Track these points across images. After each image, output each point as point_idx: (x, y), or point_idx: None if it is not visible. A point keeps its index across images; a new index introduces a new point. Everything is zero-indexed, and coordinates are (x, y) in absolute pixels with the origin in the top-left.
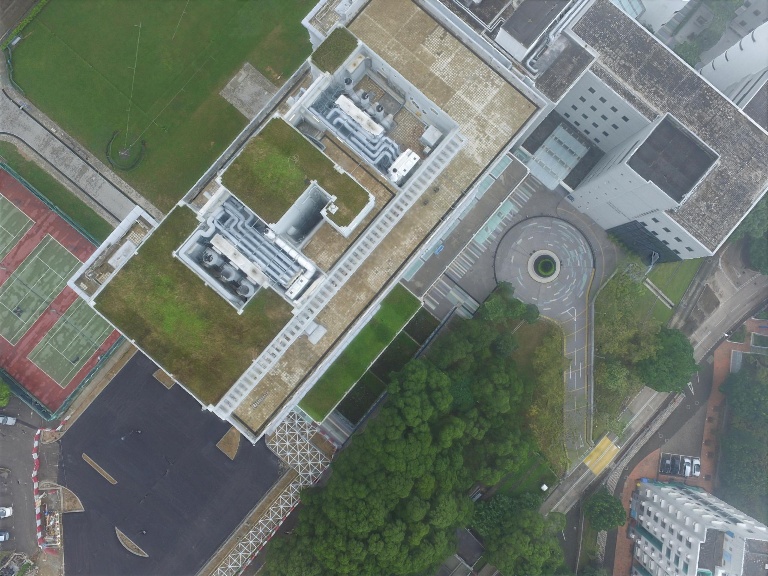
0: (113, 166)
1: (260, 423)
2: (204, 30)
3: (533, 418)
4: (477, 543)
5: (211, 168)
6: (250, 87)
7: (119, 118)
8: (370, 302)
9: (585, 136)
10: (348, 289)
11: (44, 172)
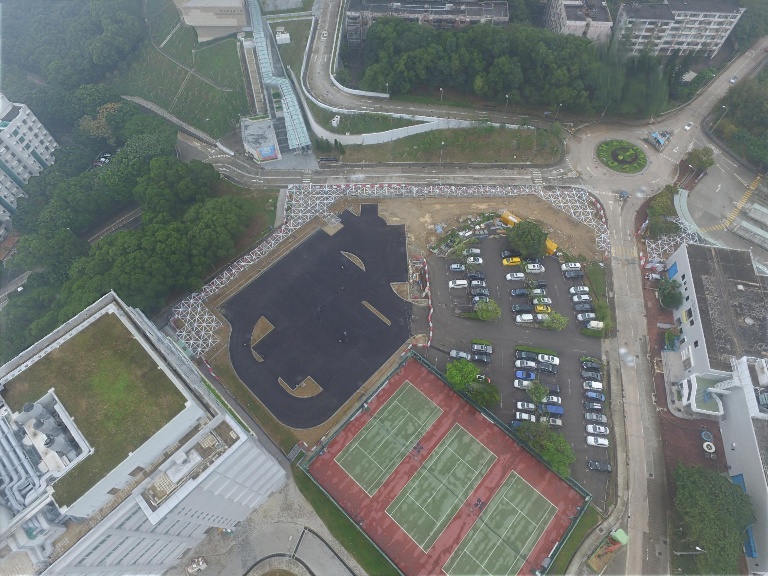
0: None
1: None
2: None
3: None
4: None
5: (48, 569)
6: None
7: None
8: None
9: None
10: None
11: None
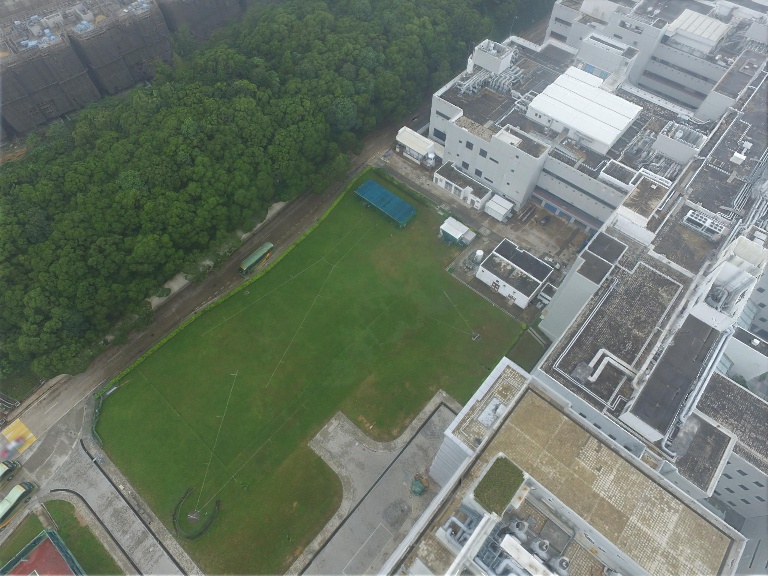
0: (178, 533)
1: None
2: (298, 379)
3: None
4: None
5: None
6: (340, 437)
7: (196, 473)
8: None
9: (714, 496)
10: None
11: (96, 541)
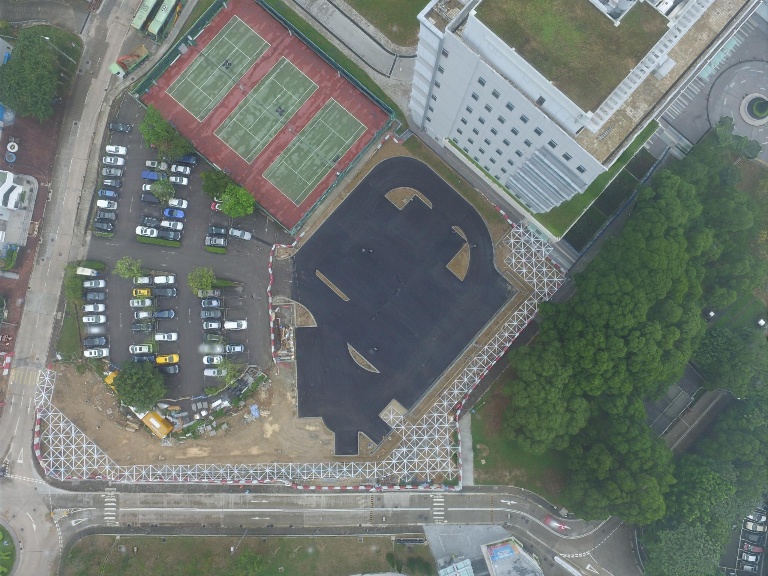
0: None
1: (606, 155)
2: None
3: (759, 247)
4: (696, 374)
5: None
6: None
7: None
8: (712, 42)
9: None
10: (691, 29)
11: None
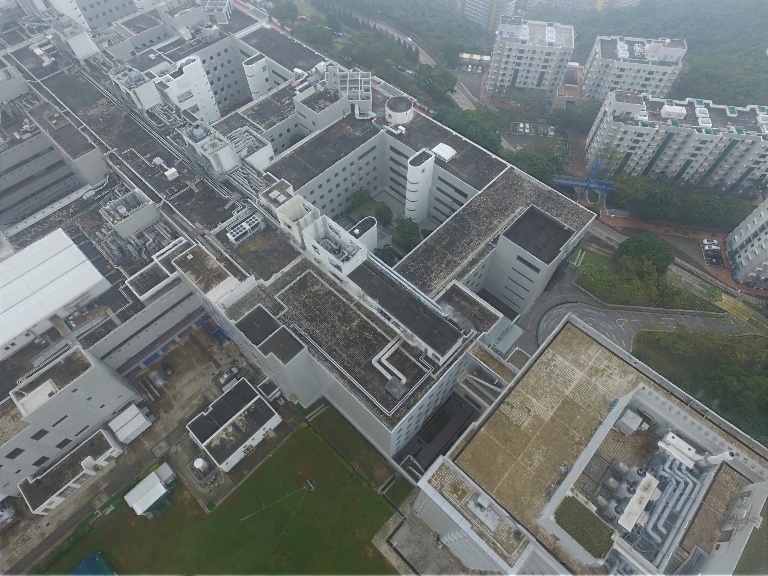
0: None
1: None
2: None
3: None
4: None
5: None
6: None
7: None
8: None
9: None
10: None
11: None
